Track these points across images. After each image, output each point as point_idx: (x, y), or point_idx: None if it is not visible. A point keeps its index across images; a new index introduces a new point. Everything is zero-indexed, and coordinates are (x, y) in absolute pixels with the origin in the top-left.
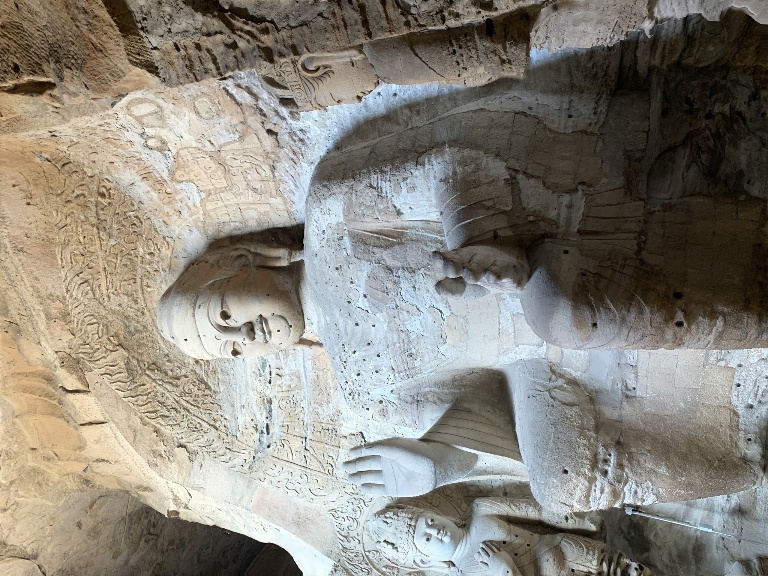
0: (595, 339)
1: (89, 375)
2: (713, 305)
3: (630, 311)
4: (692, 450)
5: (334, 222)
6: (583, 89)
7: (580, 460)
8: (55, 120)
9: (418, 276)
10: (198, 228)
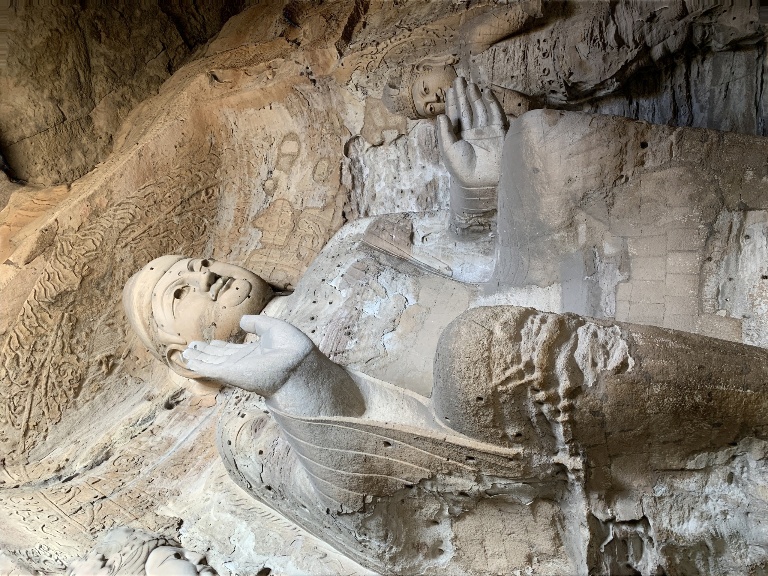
0: (561, 123)
1: (40, 260)
2: None
3: None
4: None
5: (356, 233)
6: None
7: None
8: (259, 86)
9: (401, 275)
10: None
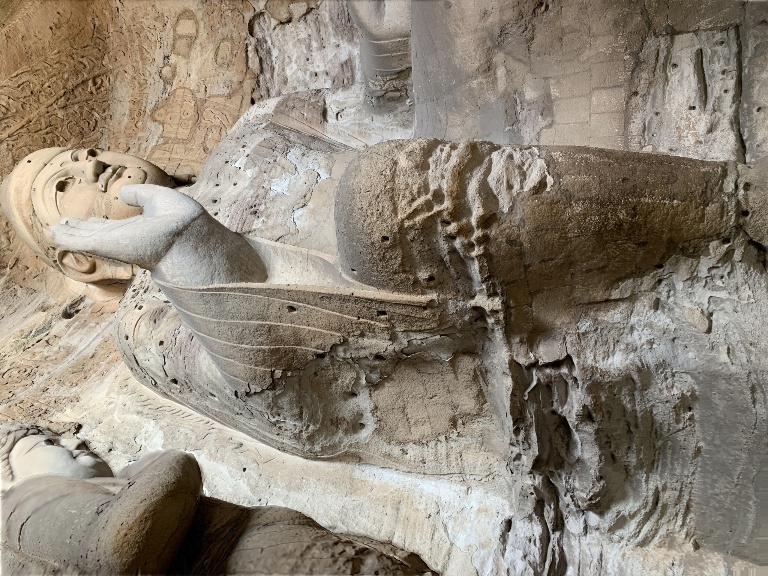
0: None
1: None
2: None
3: None
4: None
5: (263, 113)
6: None
7: None
8: None
9: (313, 152)
10: None
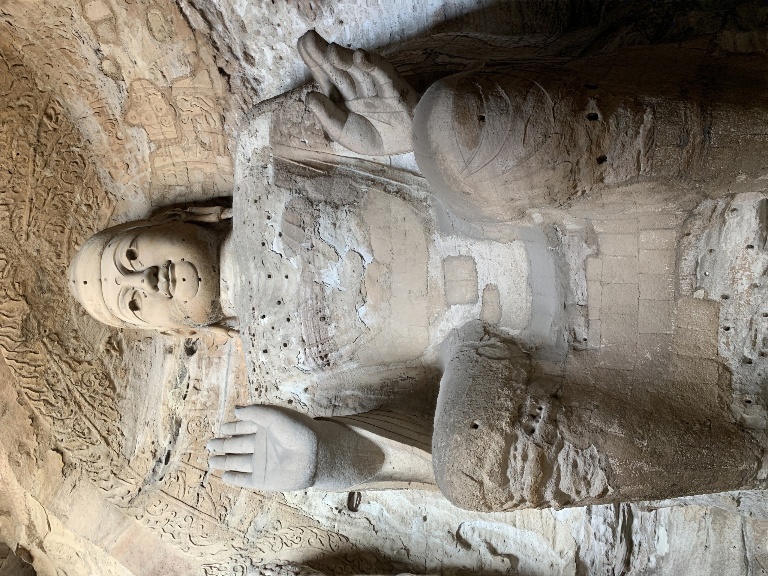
0: (484, 142)
1: None
2: (637, 95)
3: (526, 99)
4: (660, 409)
5: (260, 146)
6: (535, 29)
7: (497, 411)
8: None
9: (341, 212)
10: (144, 190)
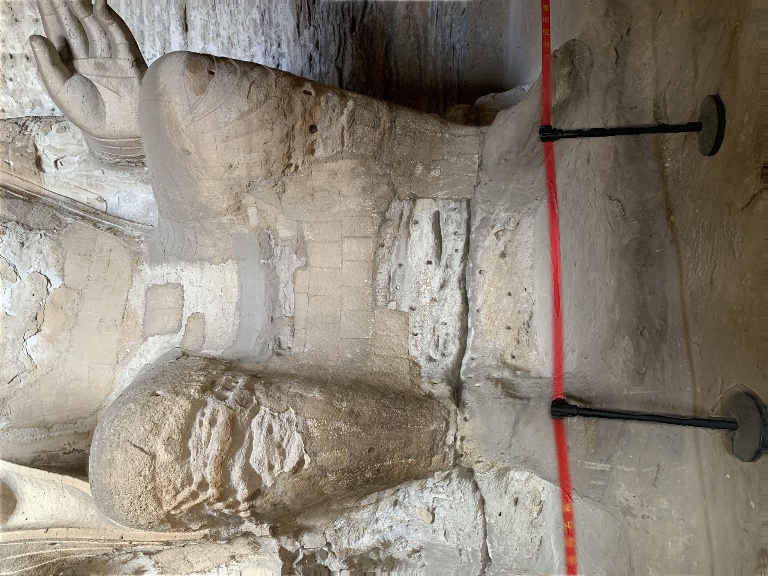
0: (211, 90)
1: None
2: (343, 91)
3: (253, 70)
4: (359, 385)
5: None
6: None
7: (186, 383)
8: None
9: (34, 235)
10: None
